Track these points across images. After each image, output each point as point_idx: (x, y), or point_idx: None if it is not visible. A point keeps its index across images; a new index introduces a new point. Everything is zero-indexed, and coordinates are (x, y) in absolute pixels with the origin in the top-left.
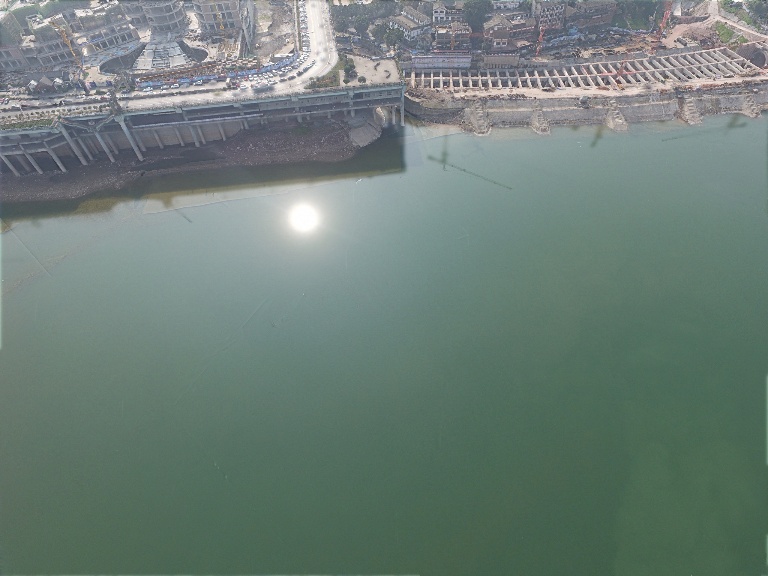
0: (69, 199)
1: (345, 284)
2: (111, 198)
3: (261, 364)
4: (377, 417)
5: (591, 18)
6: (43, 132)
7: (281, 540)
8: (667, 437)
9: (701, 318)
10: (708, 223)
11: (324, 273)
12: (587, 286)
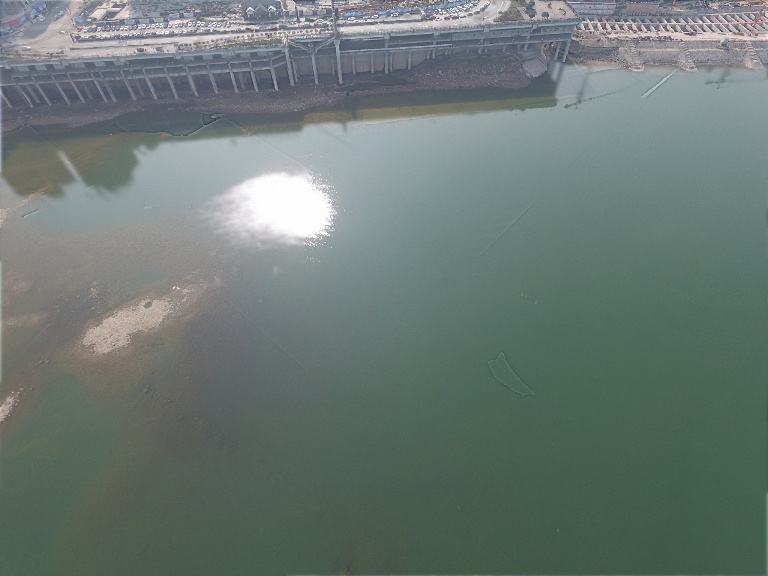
0: (292, 112)
1: (580, 173)
2: (329, 112)
3: (517, 235)
4: (629, 271)
5: None
6: (273, 51)
7: (589, 346)
8: None
9: None
10: None
11: None
12: None
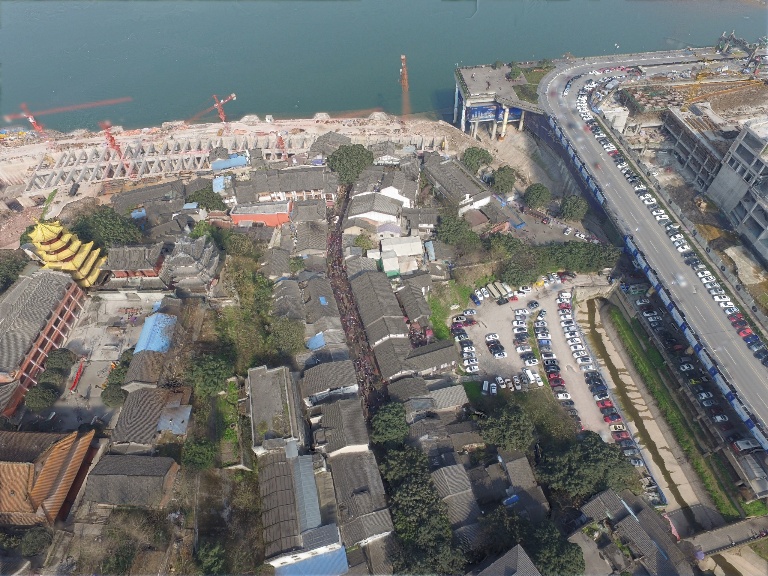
0: None
1: (479, 18)
2: None
3: None
4: None
5: None
6: None
7: None
8: (345, 7)
9: (302, 29)
10: (256, 59)
11: None
12: (349, 36)
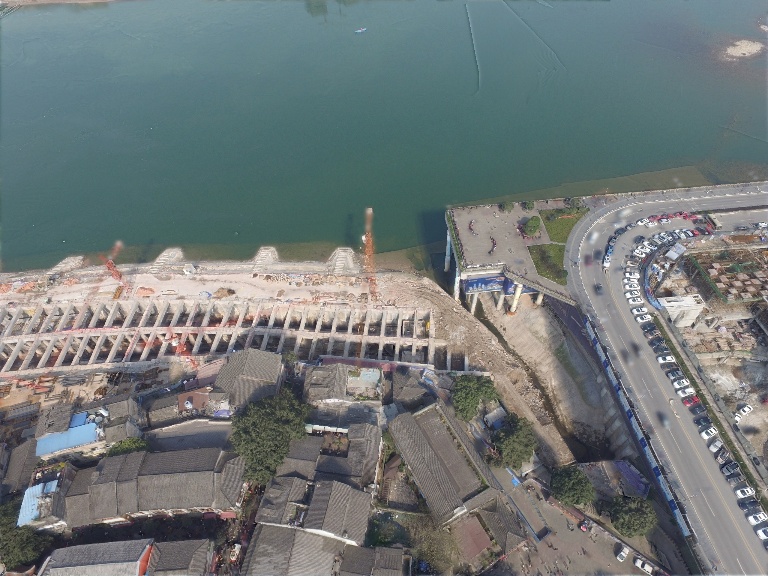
0: None
1: None
2: (748, 181)
3: None
4: (454, 79)
5: None
6: None
7: None
8: (319, 71)
9: (262, 104)
10: (197, 151)
11: (495, 80)
12: (318, 117)
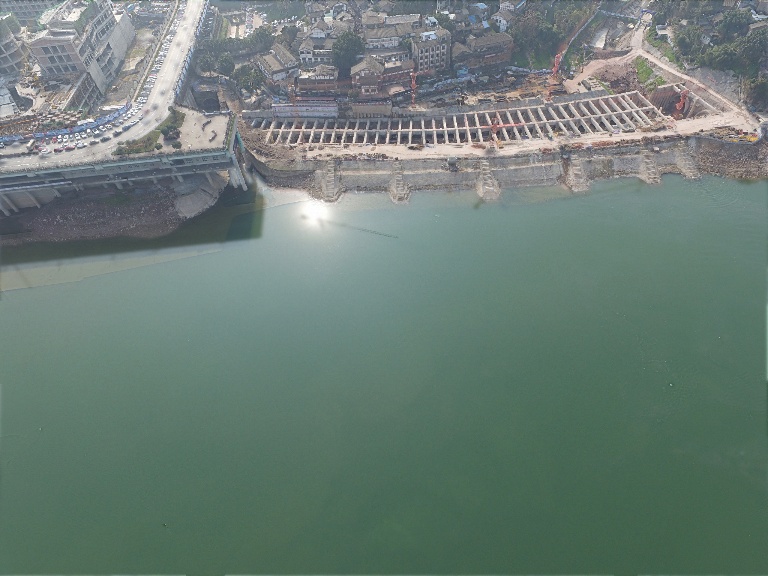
0: None
1: (72, 426)
2: None
3: None
4: None
5: (484, 57)
6: None
7: None
8: None
9: (504, 480)
10: (554, 334)
11: (29, 421)
12: (379, 426)
